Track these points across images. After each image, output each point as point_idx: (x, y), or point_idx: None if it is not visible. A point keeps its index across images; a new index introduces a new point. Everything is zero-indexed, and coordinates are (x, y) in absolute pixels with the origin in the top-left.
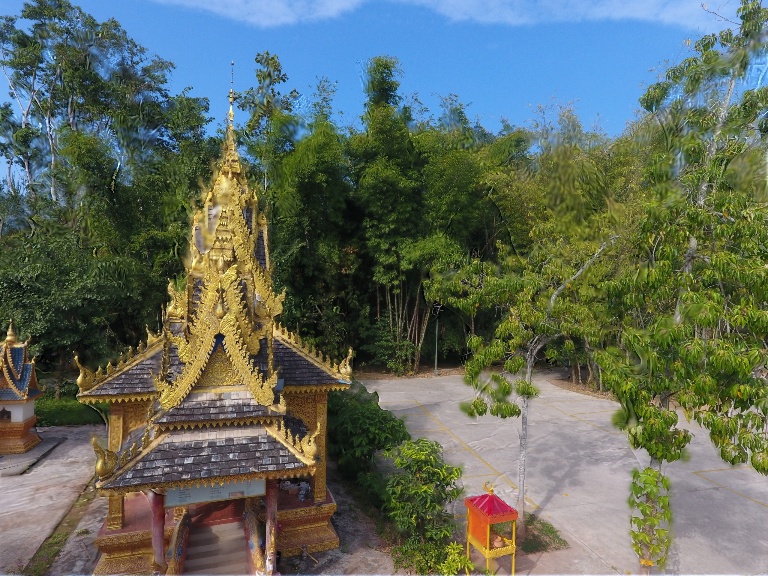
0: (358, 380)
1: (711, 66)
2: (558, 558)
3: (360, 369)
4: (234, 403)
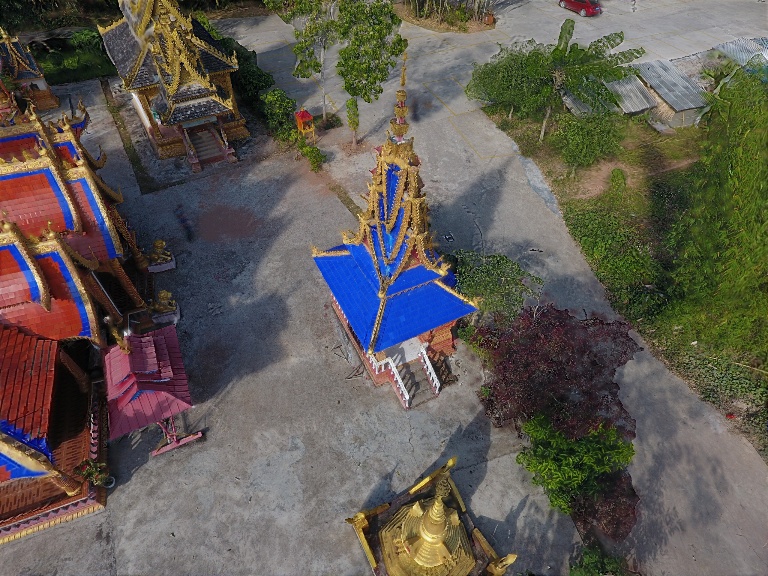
0: (241, 18)
1: None
2: (337, 130)
3: (240, 1)
4: (196, 89)
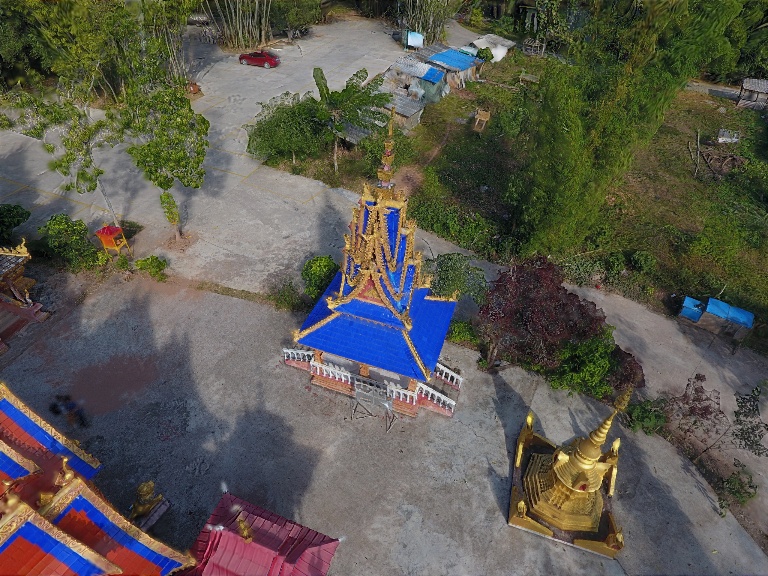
0: None
1: (131, 18)
2: (142, 234)
3: None
4: None
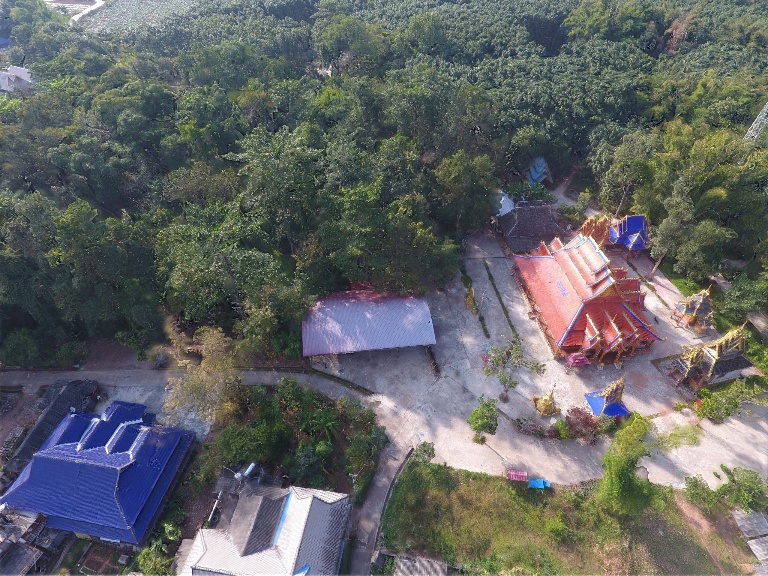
0: None
1: None
2: (708, 421)
3: None
4: None
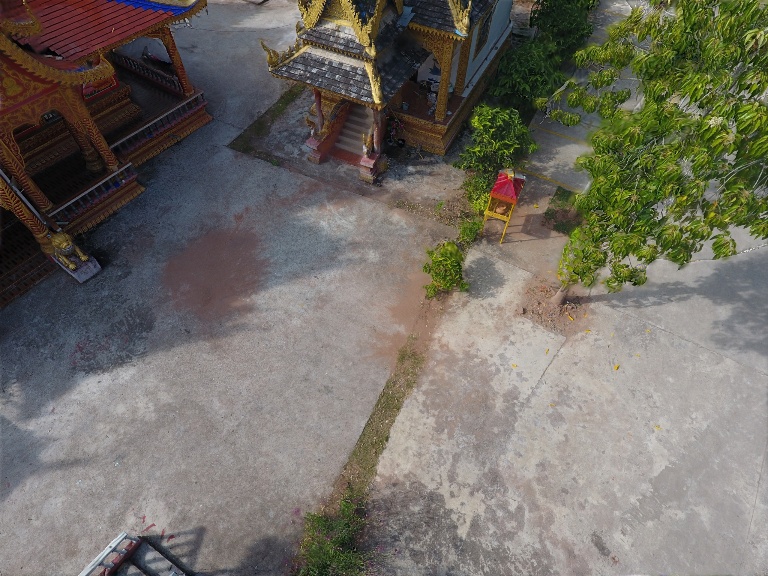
0: None
1: None
2: None
3: None
4: (345, 37)
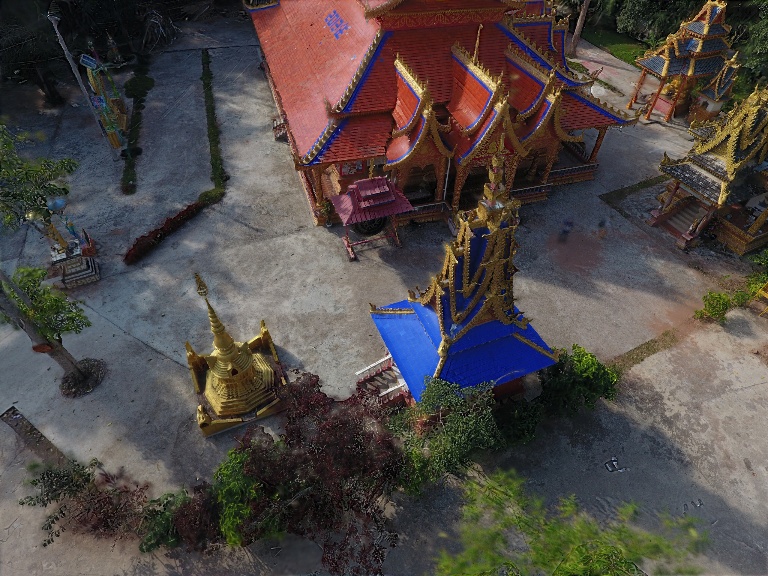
0: None
1: None
2: None
3: None
4: (718, 165)
